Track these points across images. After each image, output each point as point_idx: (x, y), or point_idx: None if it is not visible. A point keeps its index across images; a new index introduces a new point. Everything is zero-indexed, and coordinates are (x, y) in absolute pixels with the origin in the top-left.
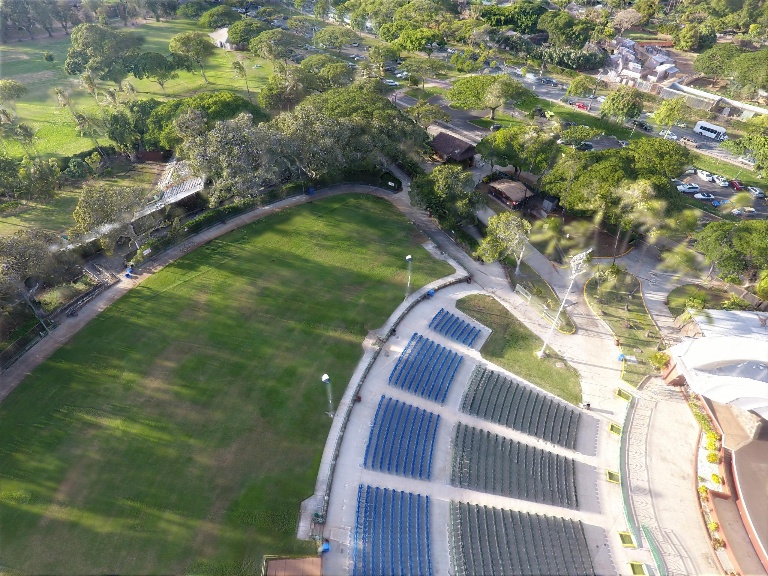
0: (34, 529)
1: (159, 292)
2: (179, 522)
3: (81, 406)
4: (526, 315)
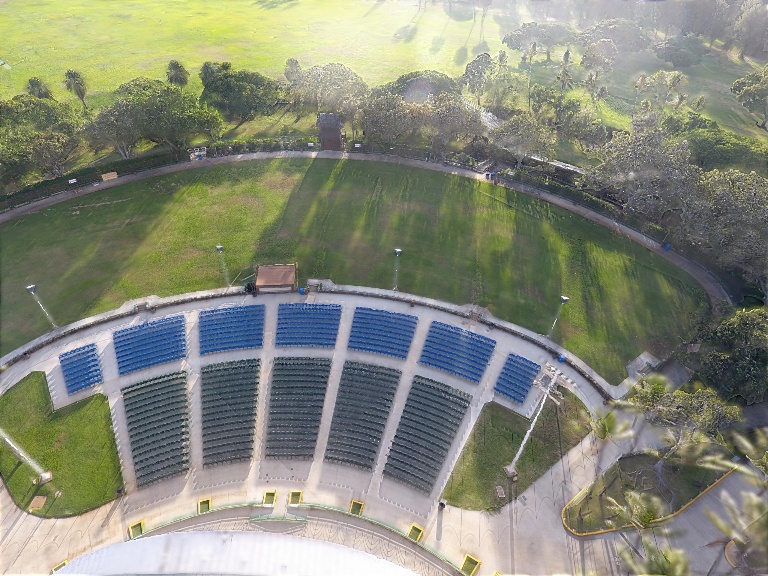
0: (316, 190)
1: (478, 190)
2: (318, 232)
3: (382, 184)
4: (576, 467)
